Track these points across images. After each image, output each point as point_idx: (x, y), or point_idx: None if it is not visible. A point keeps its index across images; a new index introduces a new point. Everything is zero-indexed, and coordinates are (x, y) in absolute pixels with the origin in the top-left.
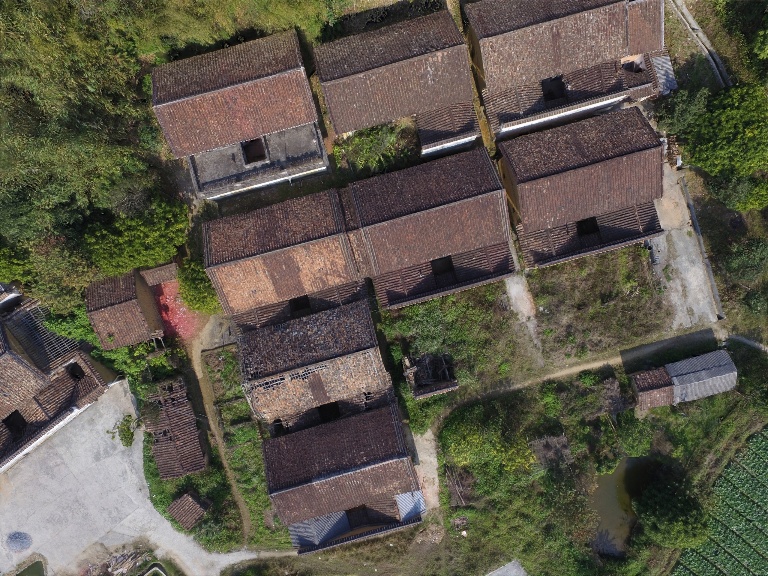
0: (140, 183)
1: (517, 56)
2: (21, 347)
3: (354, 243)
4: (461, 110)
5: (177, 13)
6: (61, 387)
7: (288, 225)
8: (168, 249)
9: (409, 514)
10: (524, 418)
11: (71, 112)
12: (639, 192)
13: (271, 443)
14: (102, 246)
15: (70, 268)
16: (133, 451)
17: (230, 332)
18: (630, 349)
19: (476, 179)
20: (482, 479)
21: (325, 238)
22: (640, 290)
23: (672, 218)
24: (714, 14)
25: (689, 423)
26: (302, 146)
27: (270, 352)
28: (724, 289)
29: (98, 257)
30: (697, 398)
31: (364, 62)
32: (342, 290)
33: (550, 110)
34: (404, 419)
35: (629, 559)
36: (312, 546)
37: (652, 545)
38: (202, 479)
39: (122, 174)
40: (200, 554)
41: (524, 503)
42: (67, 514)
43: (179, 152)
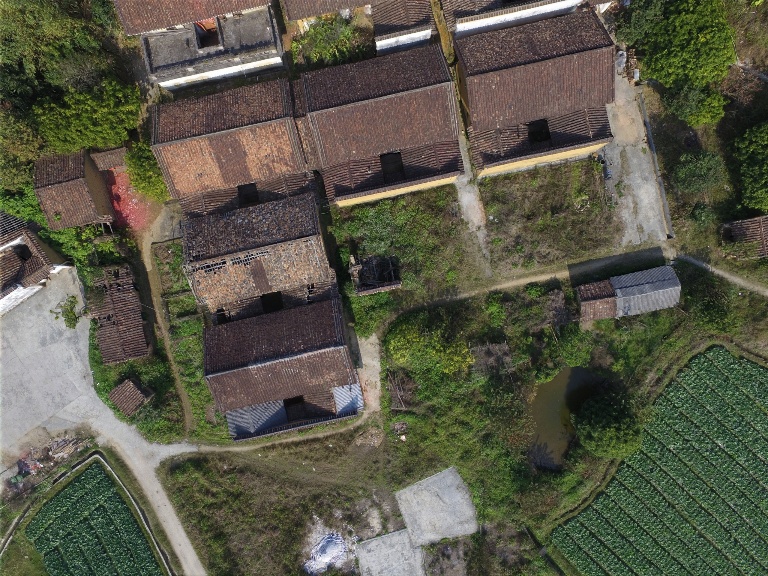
0: (92, 62)
1: None
2: None
3: (302, 131)
4: (417, 5)
5: None
6: (7, 265)
7: (237, 109)
8: (118, 131)
9: (346, 408)
10: (467, 324)
11: None
12: (590, 95)
13: (212, 330)
14: (48, 116)
15: (15, 135)
16: (79, 338)
17: (181, 226)
18: (578, 263)
19: (426, 72)
20: (423, 384)
21: (271, 121)
22: (591, 204)
23: (627, 134)
24: None
25: (632, 340)
26: (257, 35)
27: (214, 237)
28: (675, 207)
29: (44, 128)
30: (640, 312)
31: None
32: (290, 182)
33: (505, 8)
34: (350, 322)
35: (565, 472)
36: (248, 434)
37: (587, 456)
38: (144, 367)
39: (72, 48)
40: (141, 444)
41: (464, 410)
42: (11, 397)
43: (130, 29)
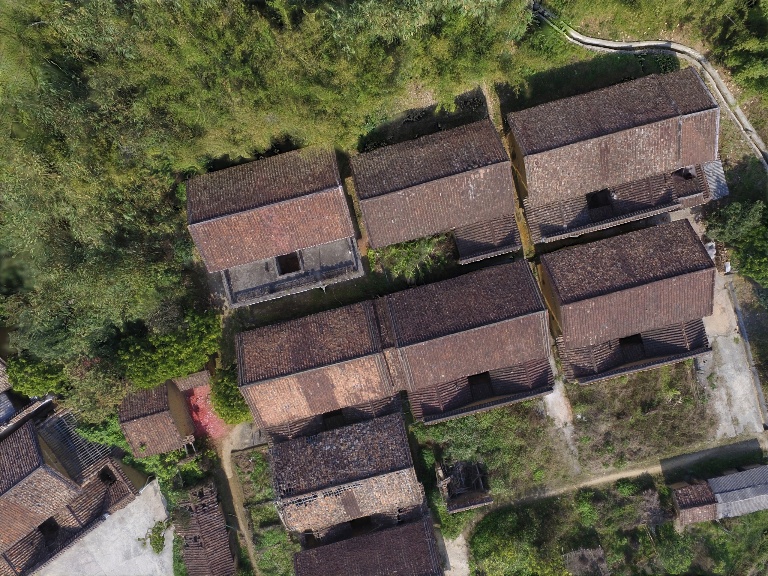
0: (173, 293)
1: (562, 171)
2: (54, 455)
3: (390, 359)
4: (501, 221)
5: (214, 141)
6: (93, 492)
7: (323, 341)
8: (200, 359)
9: None
10: (559, 529)
11: (107, 241)
12: (687, 310)
13: (302, 556)
14: (136, 364)
15: (104, 388)
16: (163, 550)
17: (260, 433)
18: (671, 458)
19: (517, 297)
20: None
21: (361, 358)
22: (683, 399)
23: (718, 324)
24: None
25: None
26: (337, 255)
27: (303, 467)
28: None
29: (132, 375)
30: (741, 514)
31: (403, 177)
32: (376, 401)
33: (595, 224)
34: (435, 523)
35: None
36: None
37: None
38: None
39: (155, 289)
40: None
41: None
42: None
43: (213, 267)
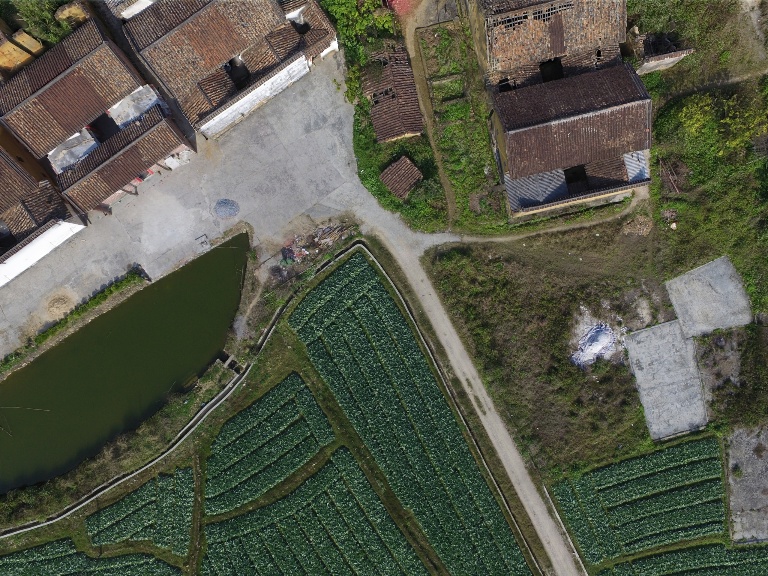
0: None
1: None
2: None
3: None
4: None
5: None
6: (288, 36)
7: None
8: None
9: (636, 178)
10: (748, 102)
11: None
12: None
13: (501, 96)
14: None
15: None
16: (343, 125)
17: (446, 10)
18: None
19: None
20: (697, 168)
21: None
22: None
23: None
24: None
25: None
26: None
27: None
28: None
29: None
30: None
31: None
32: None
33: None
34: None
35: None
36: (537, 203)
37: None
38: (418, 146)
39: None
40: (405, 232)
41: (739, 195)
42: (275, 184)
43: None
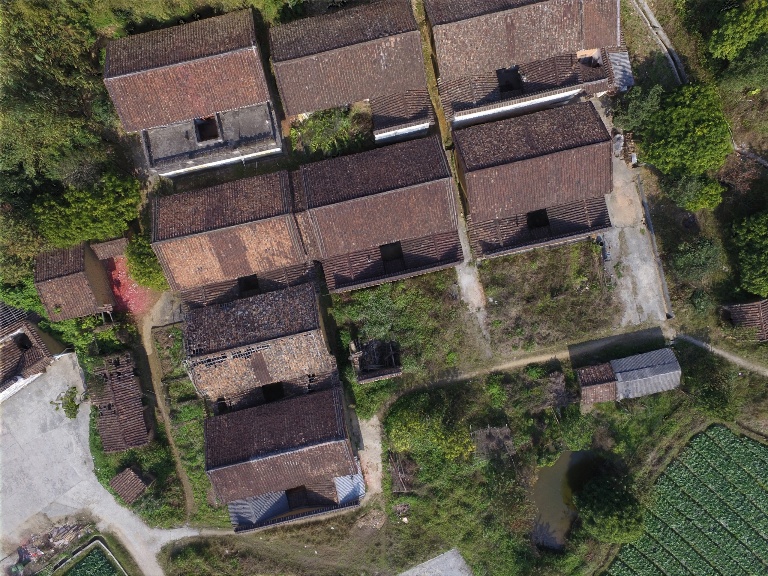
0: (92, 156)
1: (471, 45)
2: None
3: (302, 225)
4: (415, 97)
5: None
6: (7, 356)
7: (236, 204)
8: (118, 223)
9: (347, 497)
10: (468, 408)
11: (17, 80)
12: (588, 186)
13: (213, 421)
14: (48, 216)
15: (15, 237)
16: (79, 424)
17: (181, 310)
18: (578, 344)
19: (425, 166)
20: (425, 467)
21: (271, 218)
22: (590, 285)
23: (626, 215)
24: (674, 12)
25: None
26: (256, 126)
27: (214, 330)
28: (674, 288)
29: (44, 227)
30: (641, 395)
31: (317, 44)
32: (290, 272)
33: (503, 101)
34: (351, 404)
35: (568, 552)
36: (249, 524)
37: (590, 539)
38: (145, 454)
39: (72, 146)
40: (142, 529)
41: (465, 492)
42: (11, 483)
43: (130, 126)
